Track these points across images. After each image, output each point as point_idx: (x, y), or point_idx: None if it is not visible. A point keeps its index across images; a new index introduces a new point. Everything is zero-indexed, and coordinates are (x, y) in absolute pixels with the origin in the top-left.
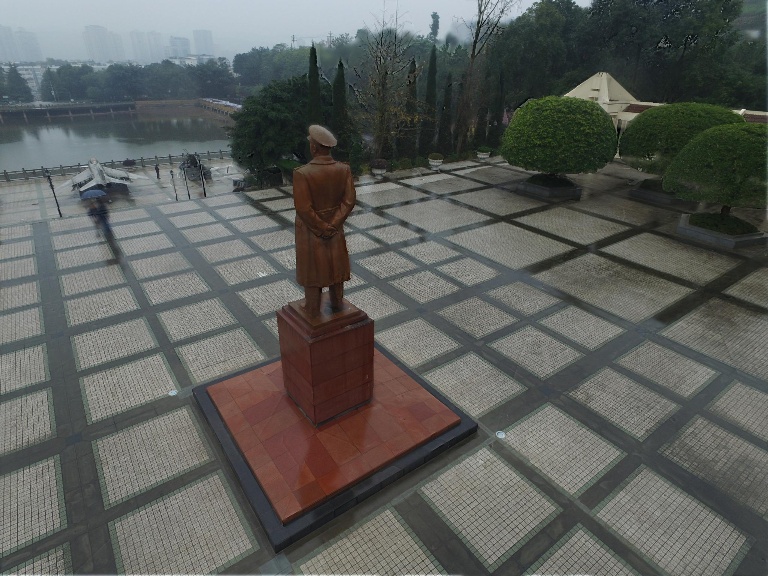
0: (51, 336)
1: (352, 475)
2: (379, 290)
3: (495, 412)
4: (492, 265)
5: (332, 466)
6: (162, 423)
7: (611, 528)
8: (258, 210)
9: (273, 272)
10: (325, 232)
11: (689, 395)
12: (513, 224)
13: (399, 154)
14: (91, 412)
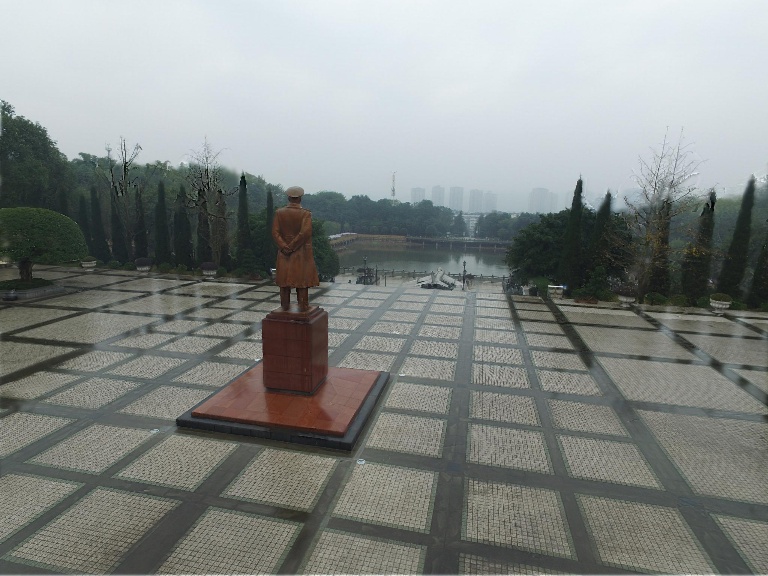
0: (260, 324)
1: (243, 416)
2: (455, 364)
3: (385, 452)
4: (606, 387)
5: (242, 408)
6: (233, 367)
7: (316, 542)
8: (465, 303)
9: (405, 333)
10: (284, 249)
11: (612, 562)
12: (721, 371)
13: (683, 291)
14: (222, 352)
